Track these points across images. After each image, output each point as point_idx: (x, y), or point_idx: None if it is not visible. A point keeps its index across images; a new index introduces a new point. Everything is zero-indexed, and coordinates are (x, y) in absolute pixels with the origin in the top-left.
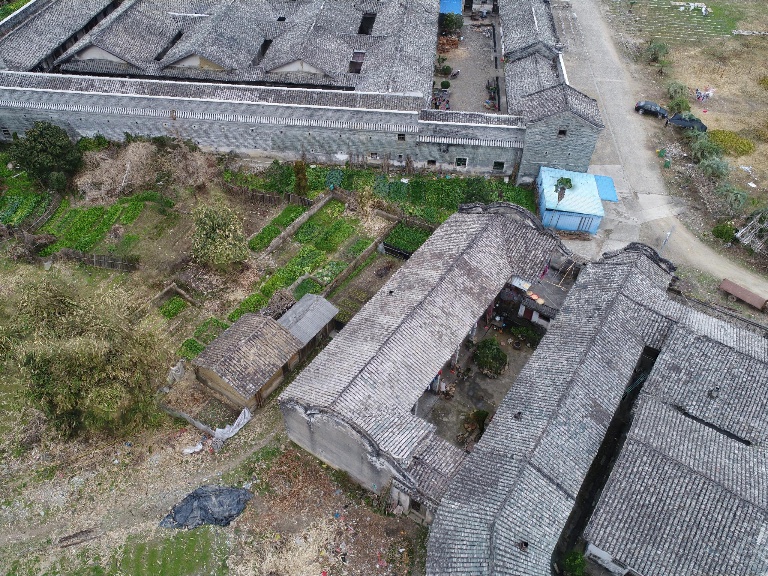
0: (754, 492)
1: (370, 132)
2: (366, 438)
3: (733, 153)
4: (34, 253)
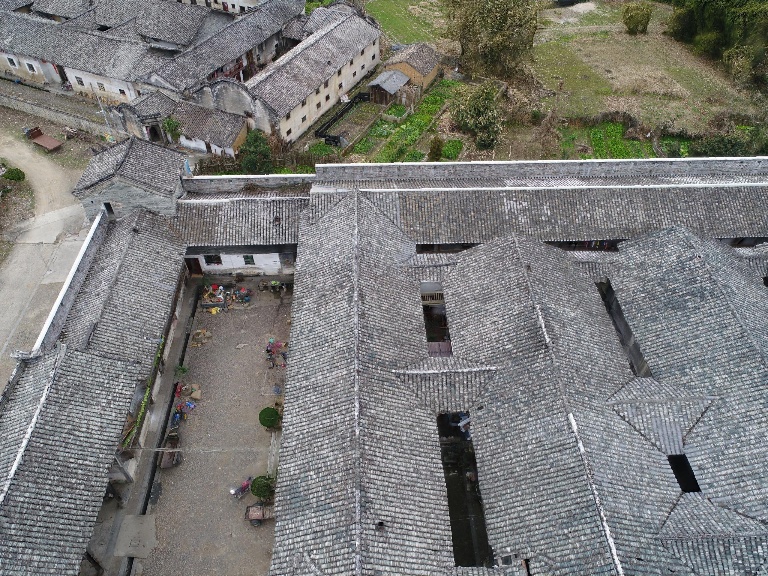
0: (164, 7)
1: None
2: None
3: None
4: (626, 125)
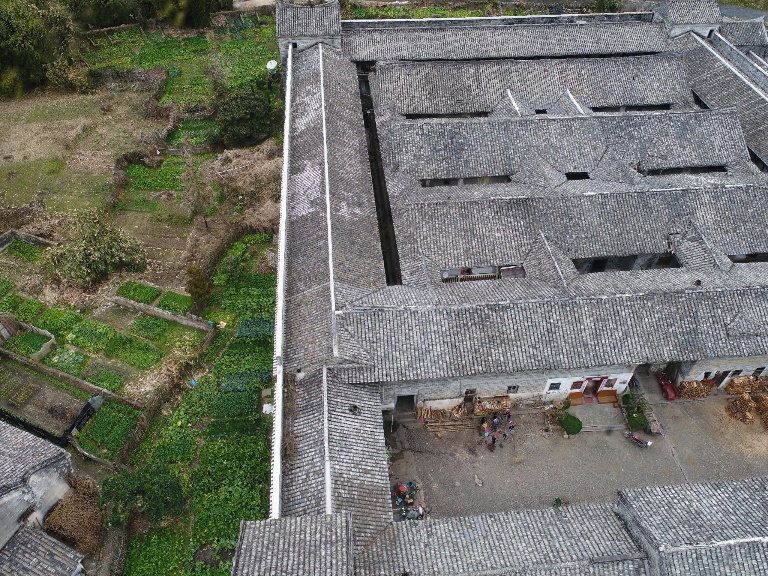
0: None
1: None
2: None
3: None
4: (134, 162)
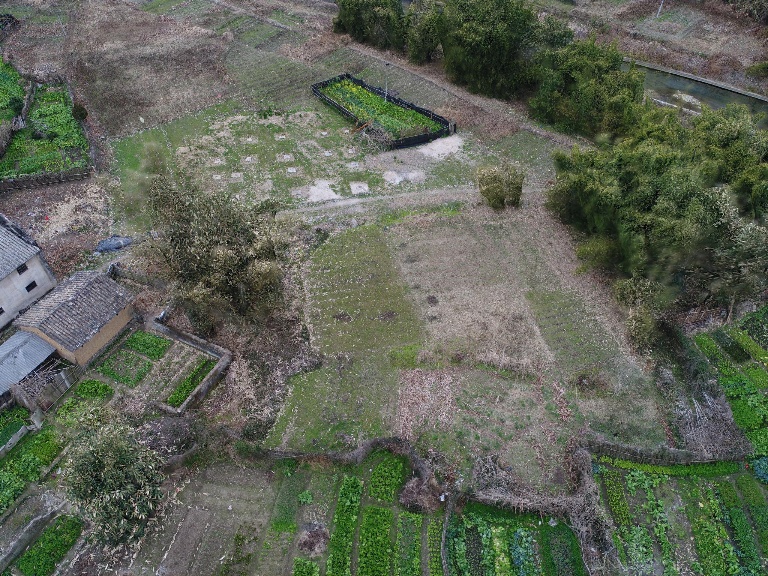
0: None
1: None
2: None
3: None
4: None
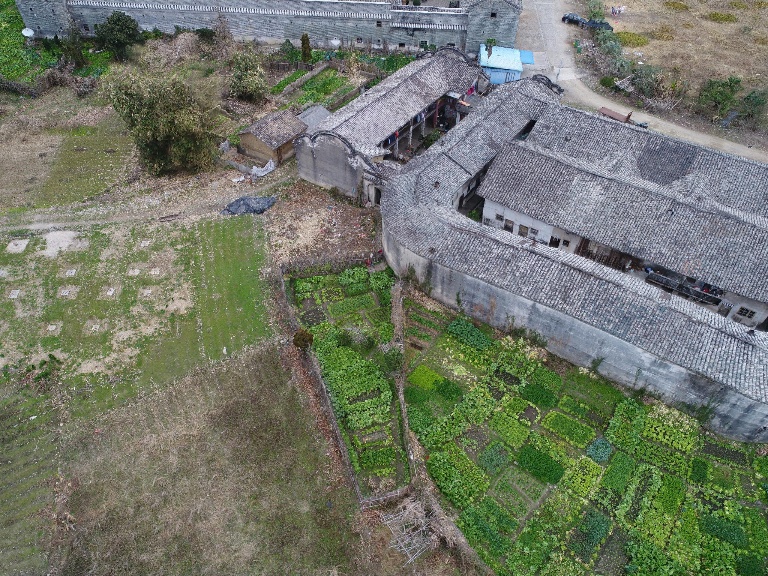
0: None
1: (356, 20)
2: (347, 142)
3: (631, 45)
4: None
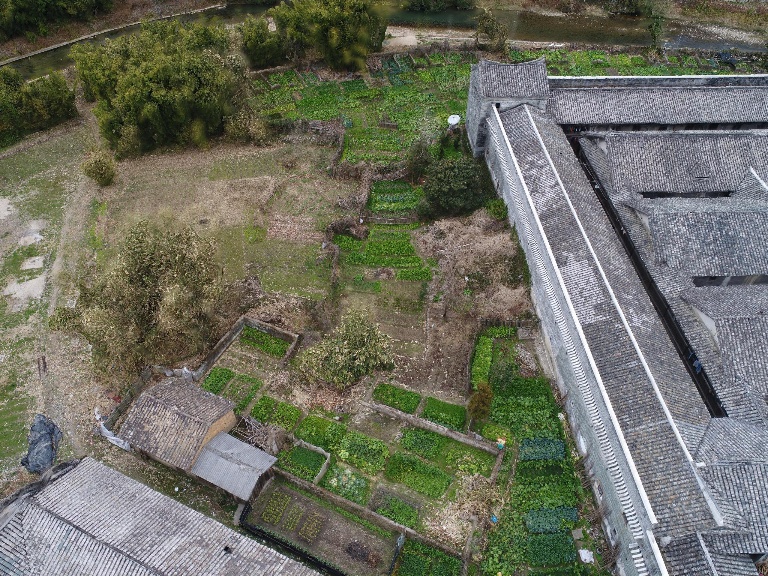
0: None
1: None
2: None
3: None
4: (340, 232)
